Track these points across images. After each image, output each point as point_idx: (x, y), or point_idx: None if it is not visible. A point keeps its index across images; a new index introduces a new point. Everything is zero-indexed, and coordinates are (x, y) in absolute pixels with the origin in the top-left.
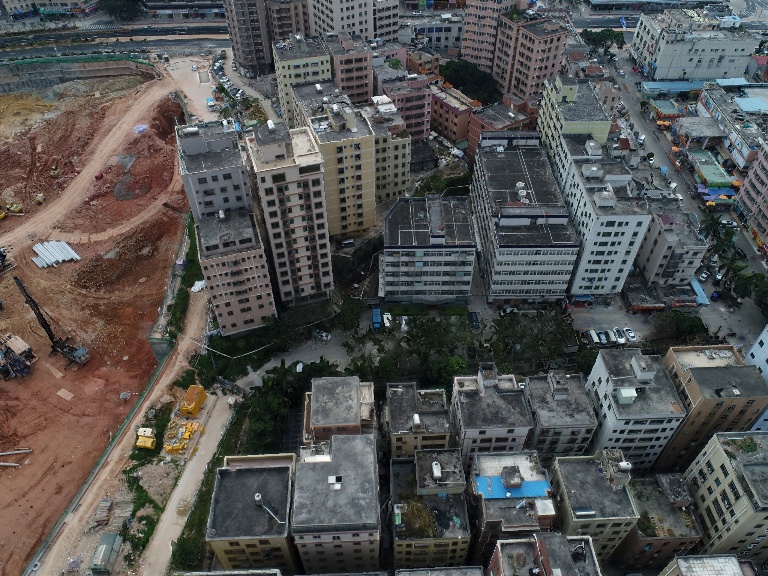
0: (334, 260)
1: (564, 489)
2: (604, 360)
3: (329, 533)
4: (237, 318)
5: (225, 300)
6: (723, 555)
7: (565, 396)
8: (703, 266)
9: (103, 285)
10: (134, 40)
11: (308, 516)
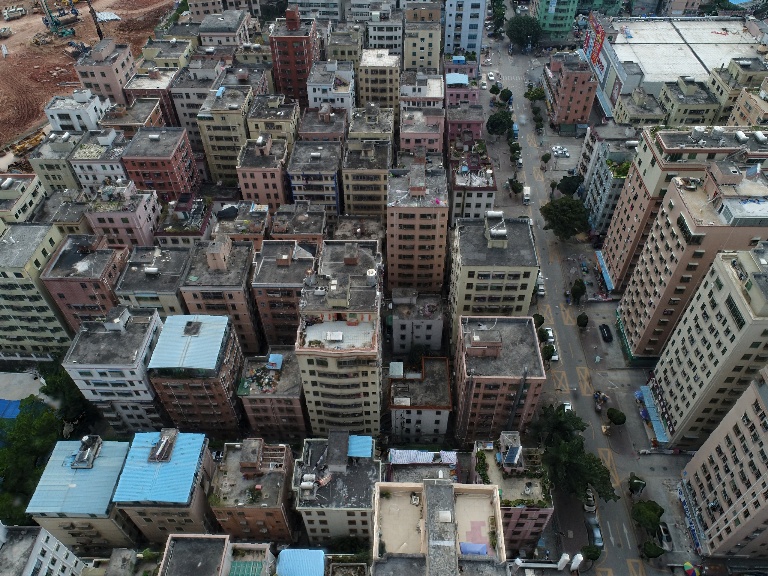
0: (266, 7)
1: (329, 39)
2: (370, 5)
3: (215, 35)
4: (202, 18)
5: (194, 2)
6: (383, 48)
7: (352, 25)
8: (493, 24)
9: (134, 30)
10: None
11: (206, 25)
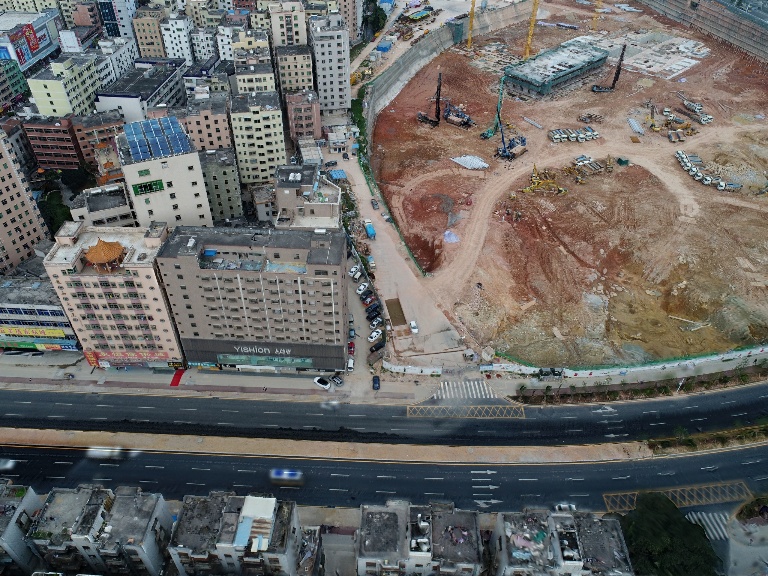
0: None
1: None
2: None
3: None
4: None
5: None
6: (193, 1)
7: None
8: None
9: None
10: (569, 447)
11: None
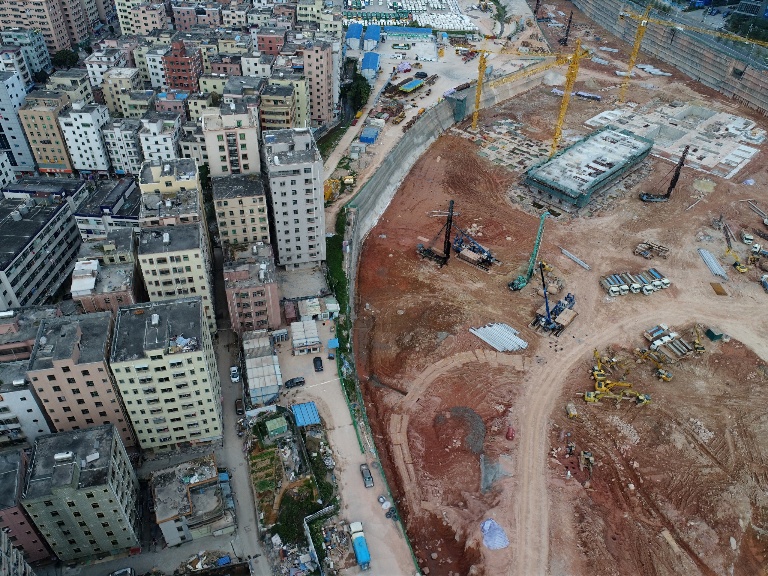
0: None
1: None
2: (93, 111)
3: None
4: None
5: None
6: None
7: None
8: None
9: None
10: None
11: (255, 78)
